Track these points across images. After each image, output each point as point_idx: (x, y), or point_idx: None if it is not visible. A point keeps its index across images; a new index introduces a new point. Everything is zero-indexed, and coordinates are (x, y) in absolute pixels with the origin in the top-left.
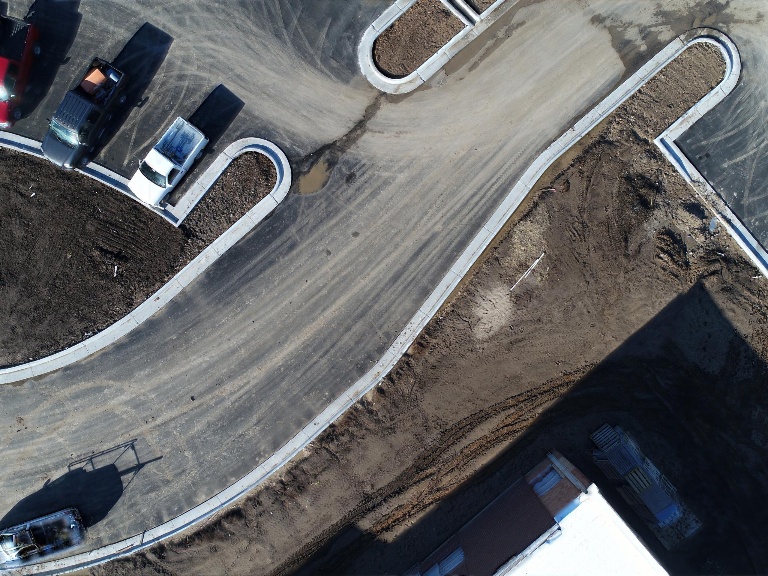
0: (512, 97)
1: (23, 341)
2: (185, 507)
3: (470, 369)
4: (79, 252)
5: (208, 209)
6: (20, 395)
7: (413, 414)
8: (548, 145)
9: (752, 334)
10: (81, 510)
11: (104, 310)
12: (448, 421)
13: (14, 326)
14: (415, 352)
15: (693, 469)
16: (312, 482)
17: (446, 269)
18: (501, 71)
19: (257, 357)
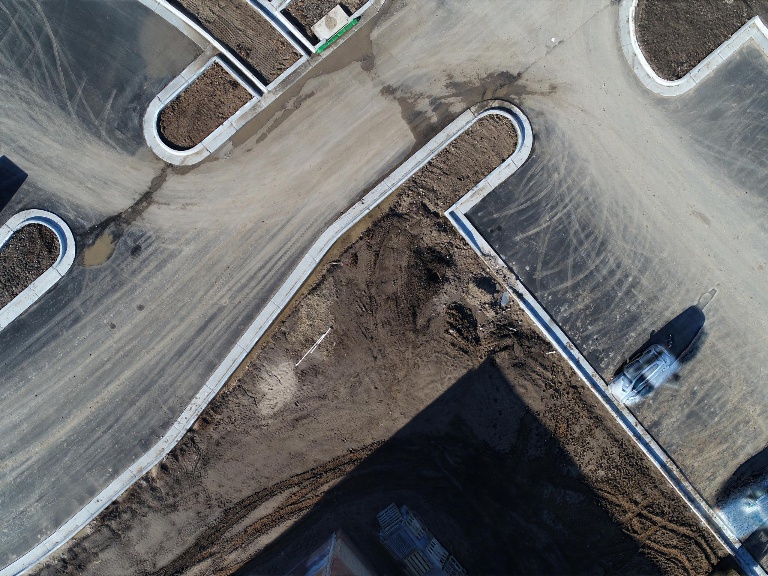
0: (300, 169)
1: None
2: None
3: (255, 446)
4: None
5: None
6: None
7: (197, 492)
8: (337, 218)
9: (545, 411)
10: None
11: None
12: (232, 499)
13: None
14: (200, 428)
15: (484, 550)
16: (93, 561)
17: (233, 343)
18: (289, 143)
19: (40, 432)
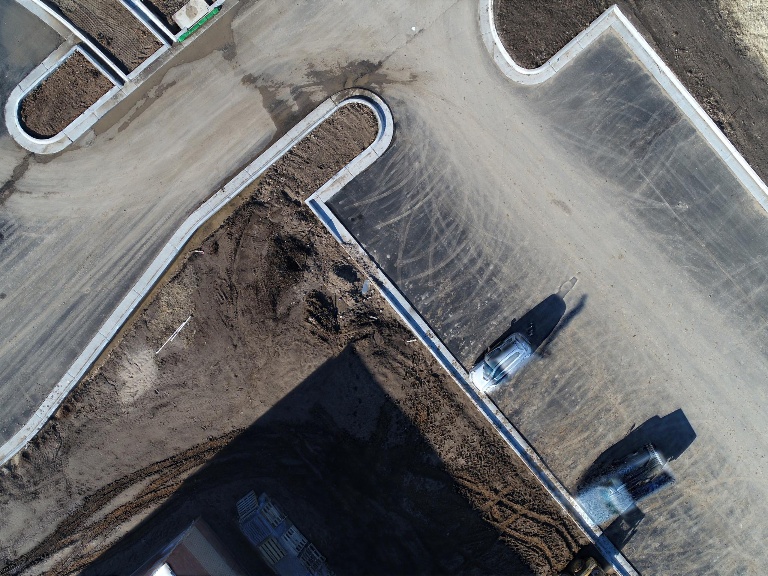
0: (162, 157)
1: None
2: None
3: (115, 434)
4: None
5: None
6: None
7: (57, 479)
8: (198, 206)
9: (405, 399)
10: None
11: None
12: (92, 487)
13: None
14: (61, 416)
15: (343, 537)
16: None
17: (94, 331)
18: (151, 131)
19: None
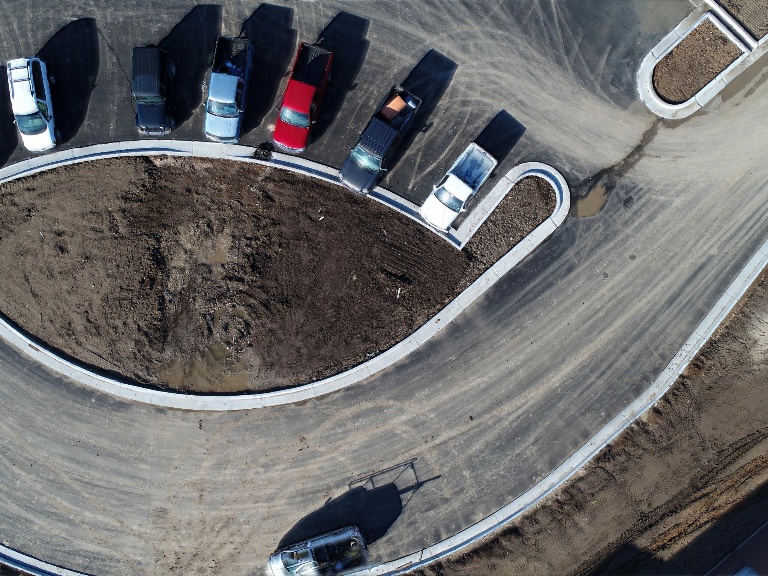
0: None
1: (307, 362)
2: (463, 525)
3: (747, 390)
4: (364, 274)
5: (489, 232)
6: (302, 415)
7: (690, 434)
8: None
9: None
10: (361, 528)
11: (386, 331)
12: (725, 441)
13: (299, 347)
14: (691, 373)
15: None
16: (589, 501)
17: (721, 291)
18: None
19: (535, 378)
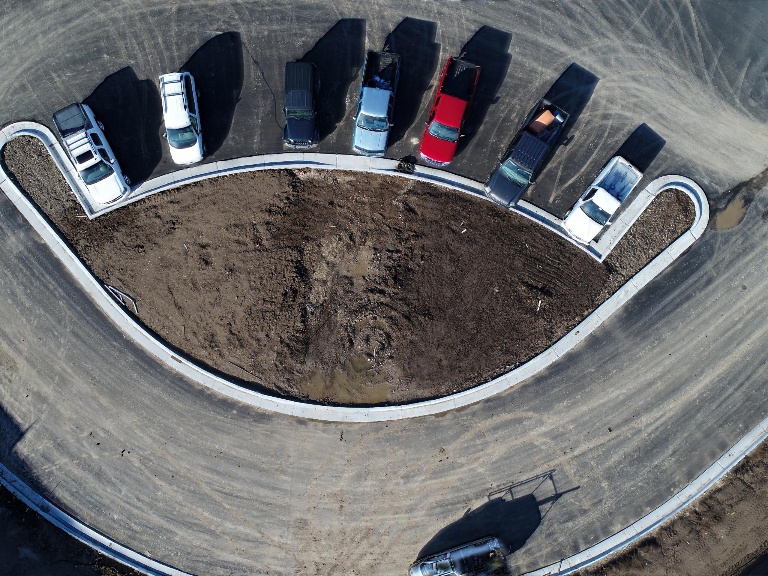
0: None
1: (448, 373)
2: (601, 536)
3: None
4: (505, 287)
5: (629, 245)
6: (442, 426)
7: None
8: None
9: None
10: (500, 539)
11: (526, 343)
12: None
13: (440, 359)
14: None
15: None
16: (728, 512)
17: None
18: None
19: (673, 389)
